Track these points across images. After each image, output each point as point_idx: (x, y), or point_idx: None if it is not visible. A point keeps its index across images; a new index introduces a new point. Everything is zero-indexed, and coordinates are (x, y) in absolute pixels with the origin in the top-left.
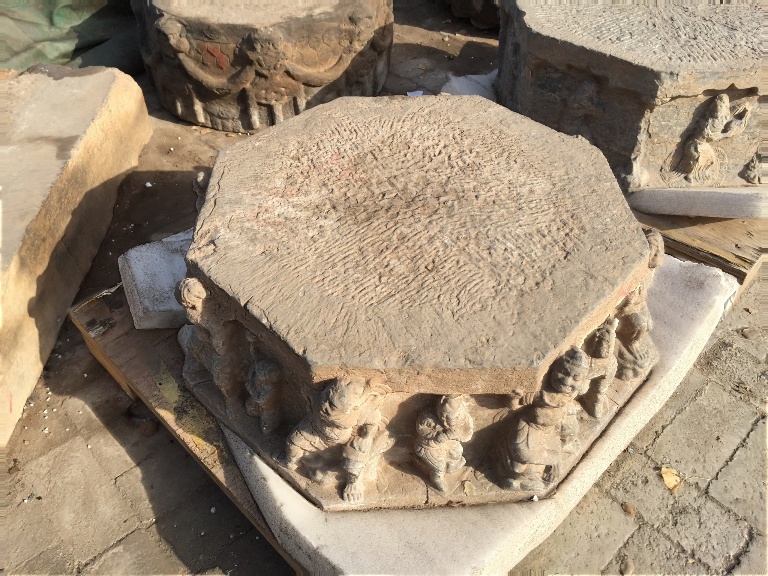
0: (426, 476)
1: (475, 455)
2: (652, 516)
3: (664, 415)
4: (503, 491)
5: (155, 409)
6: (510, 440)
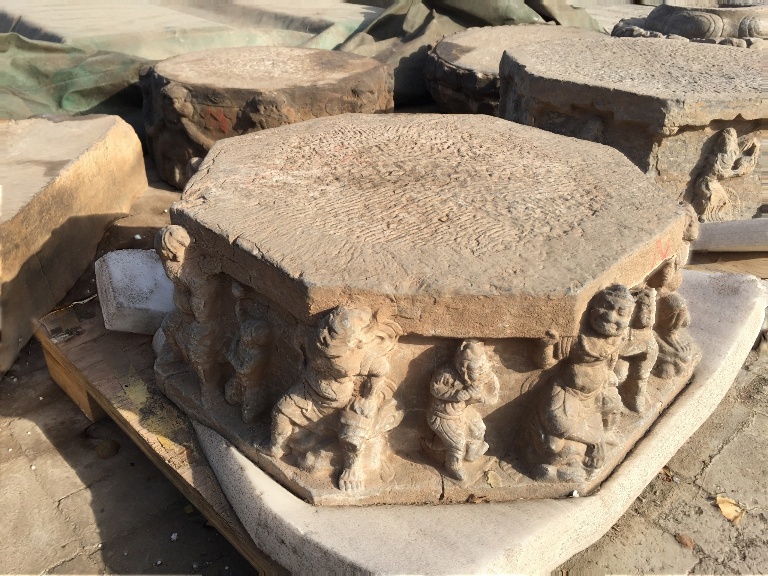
0: (441, 465)
1: (499, 443)
2: (714, 549)
3: (710, 445)
4: (536, 483)
5: (117, 409)
6: (543, 409)
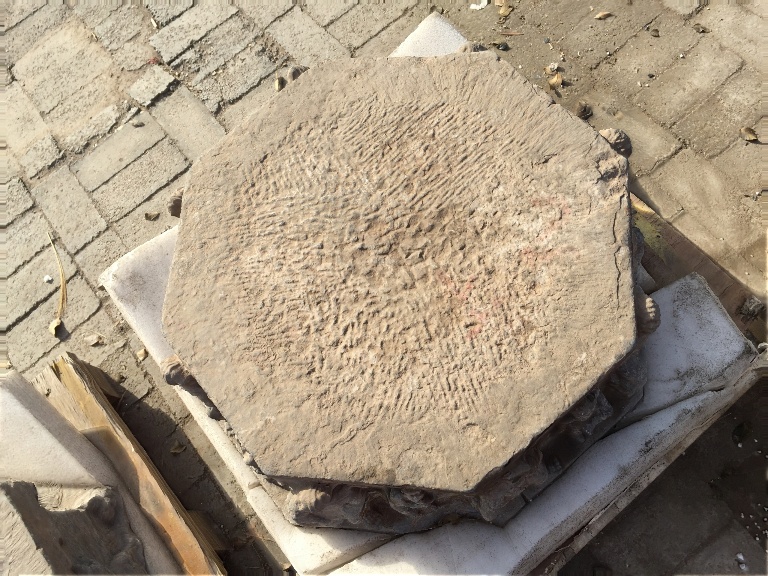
0: None
1: None
2: None
3: None
4: None
5: None
6: None
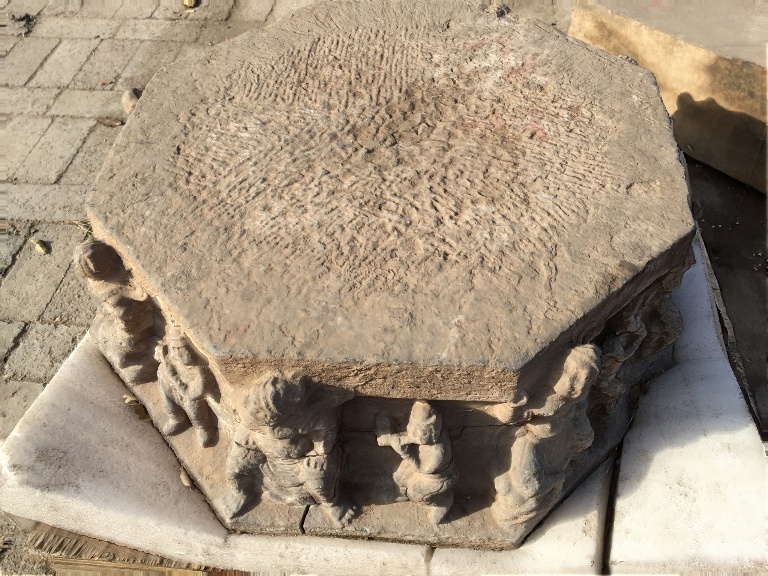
0: None
1: None
2: None
3: None
4: None
5: None
6: None
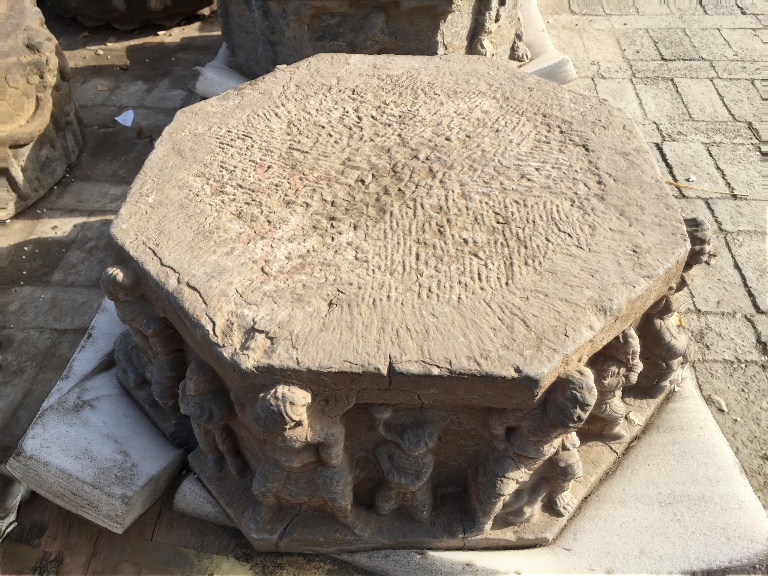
0: (598, 436)
1: None
2: None
3: None
4: (658, 400)
5: None
6: (657, 344)
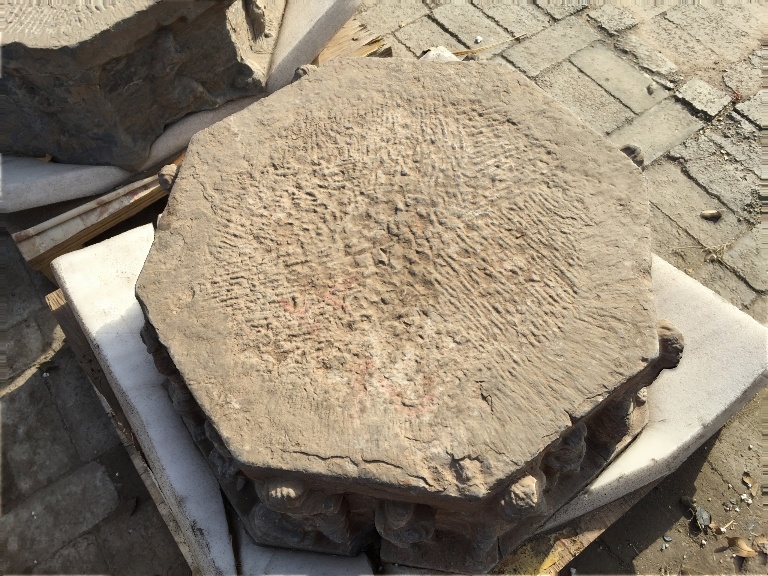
0: None
1: None
2: None
3: None
4: None
5: None
6: None
